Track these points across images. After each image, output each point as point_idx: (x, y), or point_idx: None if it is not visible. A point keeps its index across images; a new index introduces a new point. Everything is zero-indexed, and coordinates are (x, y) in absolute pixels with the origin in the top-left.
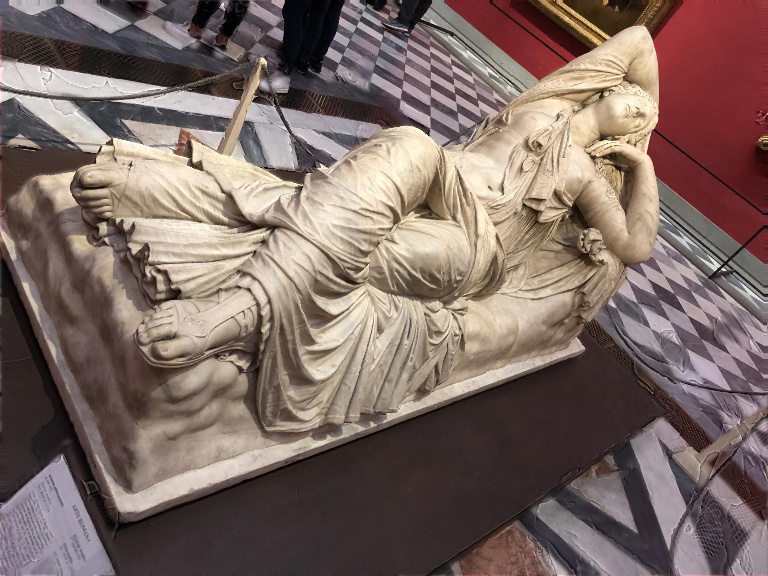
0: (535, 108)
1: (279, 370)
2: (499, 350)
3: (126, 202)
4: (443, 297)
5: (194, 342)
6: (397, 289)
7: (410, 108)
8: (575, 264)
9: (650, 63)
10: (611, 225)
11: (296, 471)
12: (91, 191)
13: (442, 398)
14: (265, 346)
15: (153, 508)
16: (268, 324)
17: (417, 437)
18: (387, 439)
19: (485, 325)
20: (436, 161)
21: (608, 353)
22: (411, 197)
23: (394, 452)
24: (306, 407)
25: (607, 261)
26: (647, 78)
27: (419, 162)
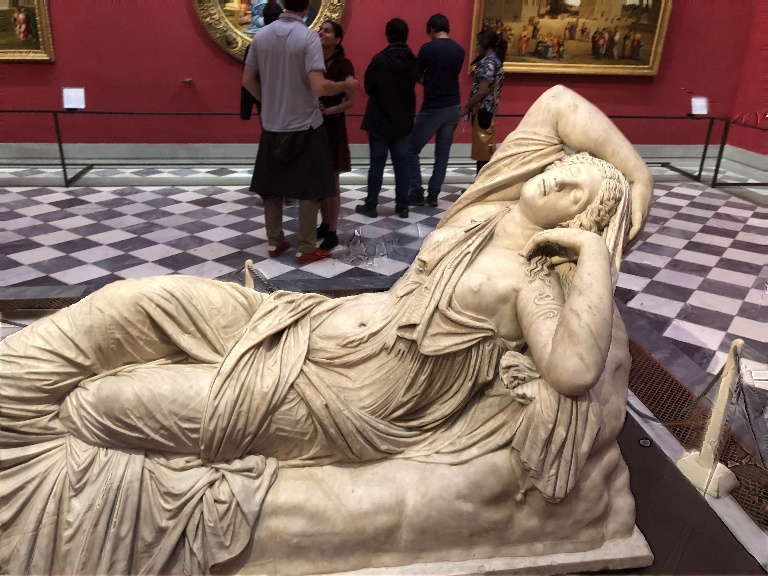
0: None
1: None
2: (362, 535)
3: None
4: (200, 453)
5: None
6: (100, 440)
7: (624, 276)
8: (511, 408)
9: (581, 120)
10: (535, 341)
11: None
12: None
13: None
14: None
15: None
16: None
17: None
18: None
19: (320, 496)
20: (137, 300)
21: (765, 573)
22: (98, 340)
23: None
24: None
25: (534, 395)
26: (589, 138)
27: (102, 304)
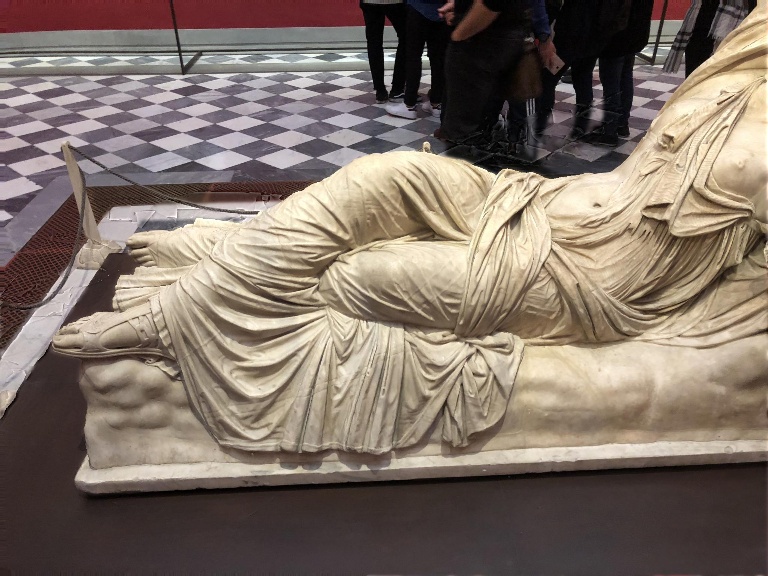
0: (691, 96)
1: (207, 381)
2: (611, 412)
3: (163, 257)
4: (455, 328)
5: (84, 336)
6: (361, 313)
7: None
8: None
9: None
10: None
11: (266, 497)
12: (136, 250)
13: (493, 460)
14: (175, 353)
15: (102, 484)
16: (166, 331)
17: (449, 502)
18: (404, 495)
19: (569, 373)
20: (391, 175)
21: None
22: (356, 214)
23: (400, 509)
24: (252, 425)
25: None
26: None
27: (358, 178)
